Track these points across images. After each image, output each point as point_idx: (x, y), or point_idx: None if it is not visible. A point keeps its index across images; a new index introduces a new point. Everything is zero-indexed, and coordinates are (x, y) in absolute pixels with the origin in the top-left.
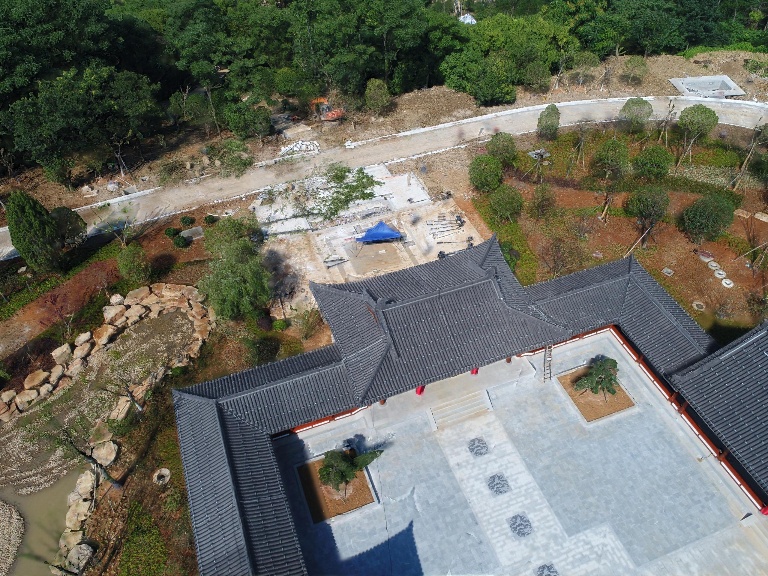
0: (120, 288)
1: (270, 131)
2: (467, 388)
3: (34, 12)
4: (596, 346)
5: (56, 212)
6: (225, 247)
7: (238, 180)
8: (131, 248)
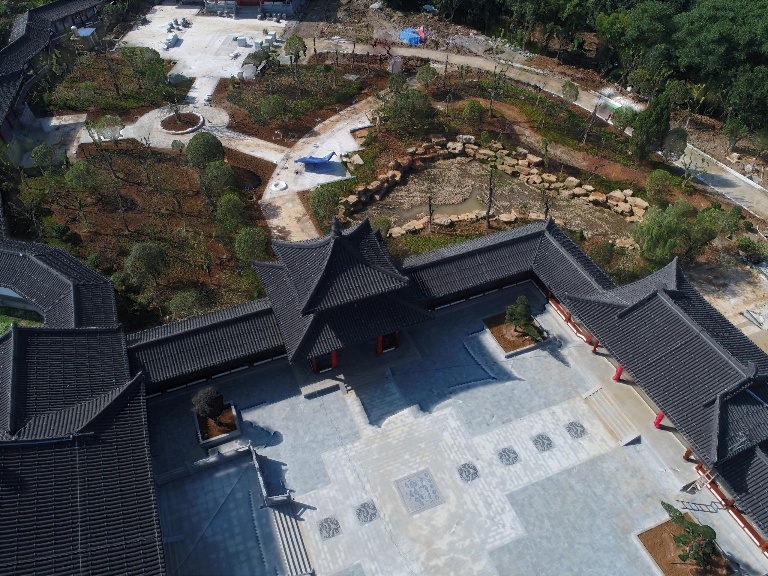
0: (640, 193)
1: None
2: (635, 418)
3: None
4: (762, 574)
5: (678, 129)
6: (681, 200)
7: None
8: (668, 173)
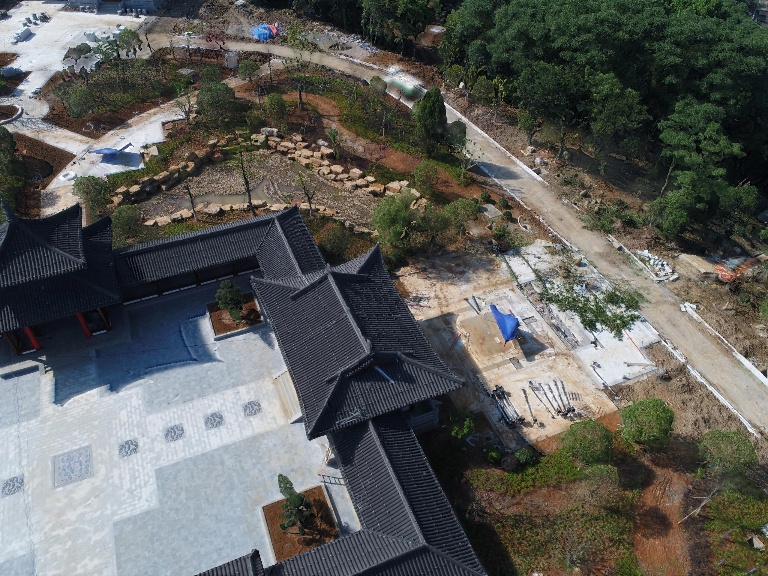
0: None
1: (691, 247)
2: None
3: (680, 35)
4: None
5: (456, 122)
6: None
7: (580, 228)
8: (431, 164)
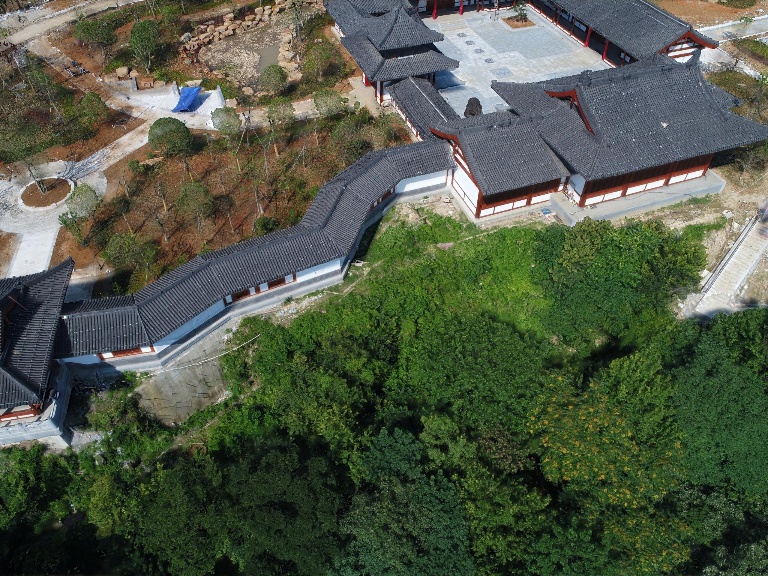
0: None
1: None
2: (457, 18)
3: None
4: None
5: None
6: None
7: None
8: None
